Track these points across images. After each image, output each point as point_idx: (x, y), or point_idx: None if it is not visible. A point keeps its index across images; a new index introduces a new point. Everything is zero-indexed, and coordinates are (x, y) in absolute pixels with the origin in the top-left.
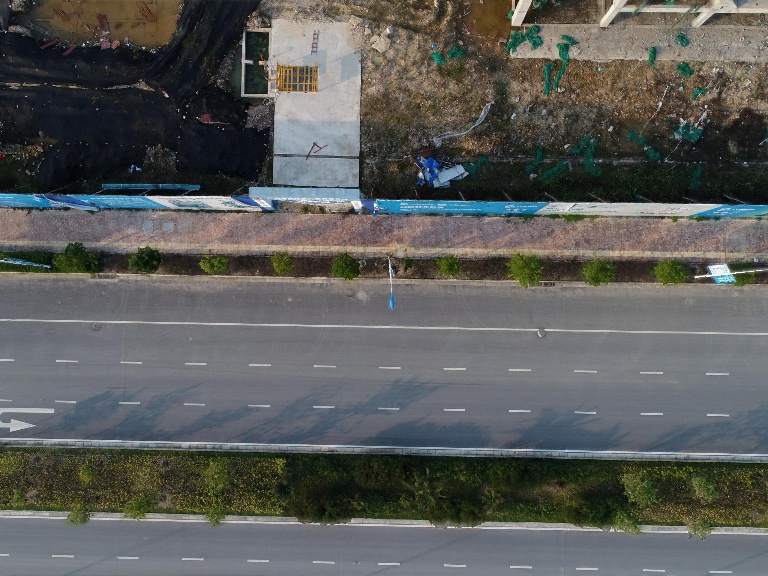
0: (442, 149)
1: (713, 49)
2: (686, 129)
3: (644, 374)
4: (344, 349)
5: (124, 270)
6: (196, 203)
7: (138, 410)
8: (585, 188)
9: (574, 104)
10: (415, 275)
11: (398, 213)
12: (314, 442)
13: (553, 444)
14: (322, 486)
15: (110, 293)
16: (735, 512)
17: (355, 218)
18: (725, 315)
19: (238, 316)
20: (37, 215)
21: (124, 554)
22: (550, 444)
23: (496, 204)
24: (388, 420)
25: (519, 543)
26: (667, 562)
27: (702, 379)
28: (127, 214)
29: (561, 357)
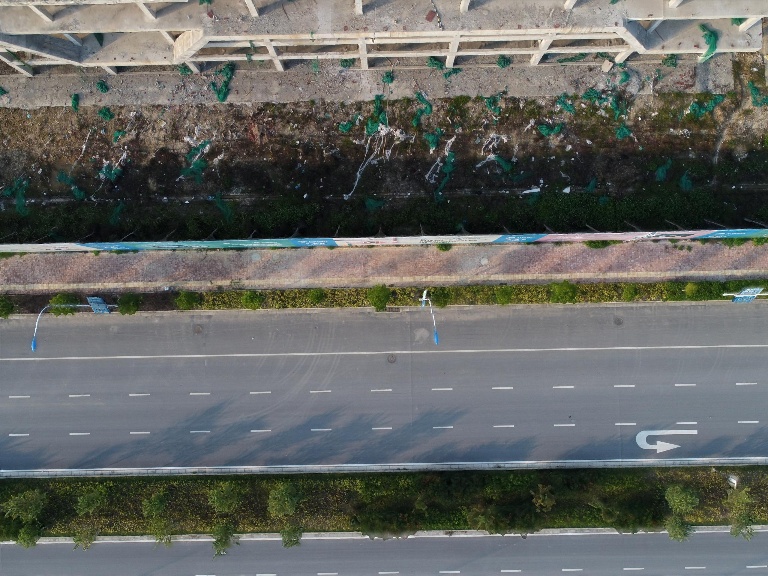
0: None
1: (131, 94)
2: (109, 169)
3: (73, 397)
4: None
5: None
6: None
7: None
8: (12, 227)
9: (6, 149)
10: None
11: None
12: None
13: None
14: None
15: None
16: (152, 521)
17: None
18: (147, 340)
19: None
20: None
21: None
22: None
23: None
24: None
25: None
26: (96, 570)
27: (126, 400)
28: None
29: None
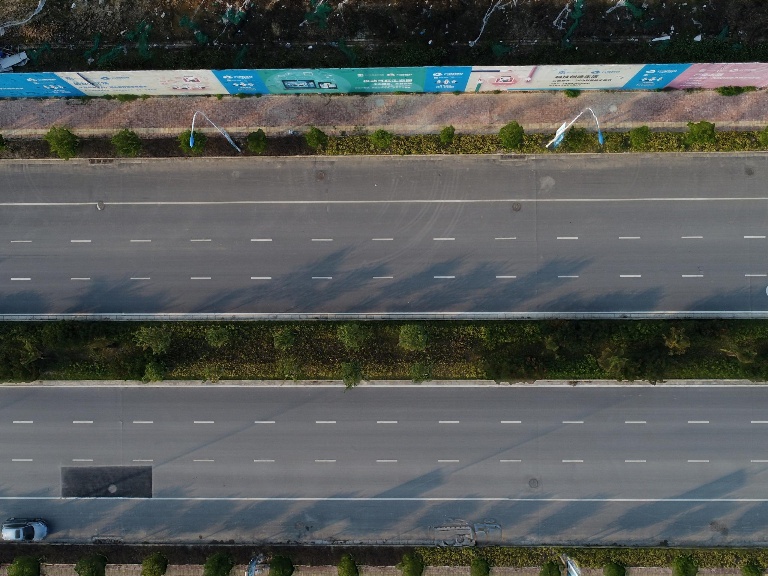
0: (5, 37)
1: None
2: (232, 13)
3: (194, 242)
4: None
5: None
6: None
7: None
8: None
9: None
10: None
11: None
12: None
13: (111, 308)
14: None
15: None
16: (274, 366)
17: None
18: (269, 185)
19: None
20: None
21: None
22: (108, 308)
23: (12, 77)
24: None
25: (81, 400)
26: (216, 414)
27: (247, 245)
28: None
29: (118, 228)
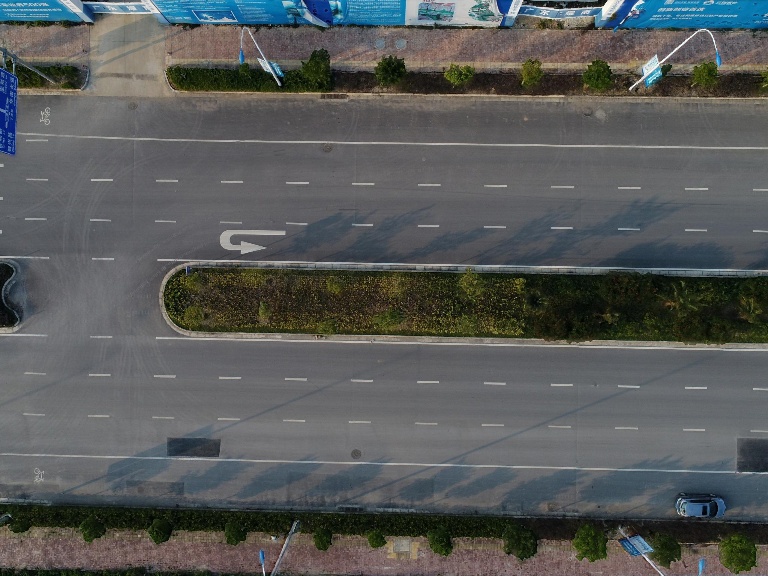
0: None
1: None
2: None
3: None
4: (582, 169)
5: (355, 89)
6: (444, 8)
7: (371, 232)
8: None
9: None
10: (656, 93)
11: (639, 28)
12: (552, 263)
13: None
14: (562, 307)
15: (340, 113)
16: None
17: (594, 34)
18: None
19: (472, 136)
20: (265, 33)
21: (358, 377)
22: None
23: None
24: (628, 241)
25: (762, 365)
26: None
27: None
28: (358, 31)
29: None
